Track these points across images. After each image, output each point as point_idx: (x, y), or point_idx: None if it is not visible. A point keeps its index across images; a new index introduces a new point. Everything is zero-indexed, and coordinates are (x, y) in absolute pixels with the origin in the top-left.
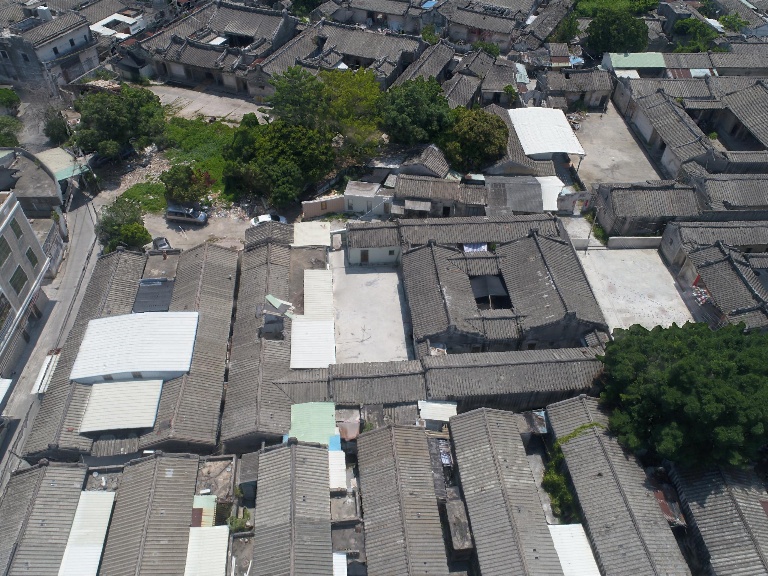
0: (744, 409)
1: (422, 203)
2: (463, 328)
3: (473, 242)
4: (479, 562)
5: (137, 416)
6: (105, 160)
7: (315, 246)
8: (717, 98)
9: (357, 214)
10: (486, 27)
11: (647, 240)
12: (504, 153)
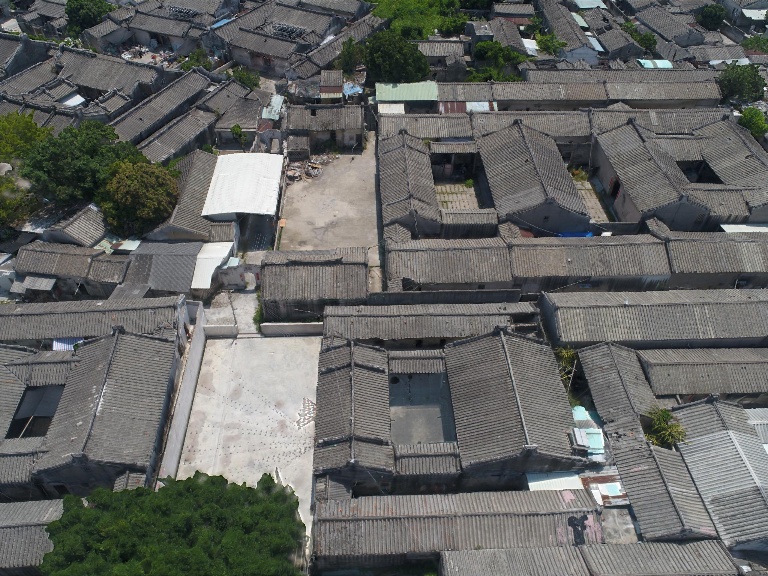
0: None
1: (45, 280)
2: None
3: (65, 337)
4: None
5: None
6: None
7: None
8: (475, 139)
9: None
10: (265, 51)
11: (308, 326)
12: (166, 215)
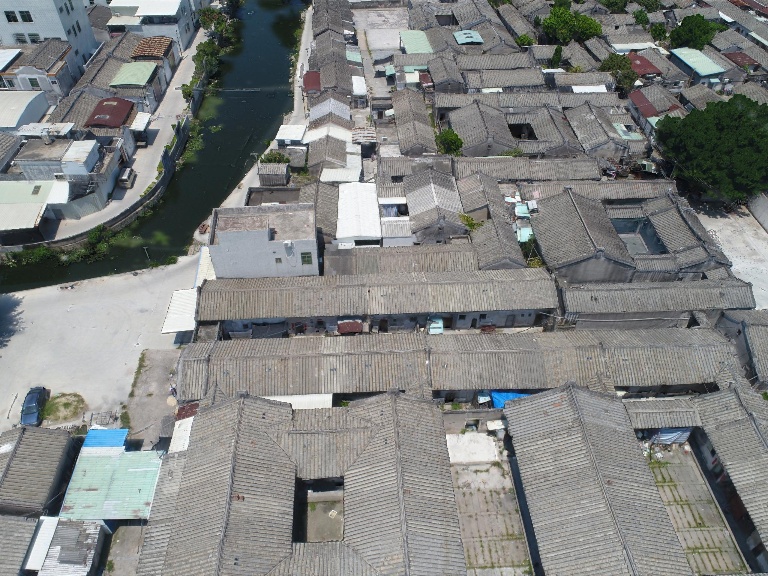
0: None
1: None
2: None
3: None
4: None
5: None
6: None
7: None
8: None
9: None
10: None
11: None
12: None
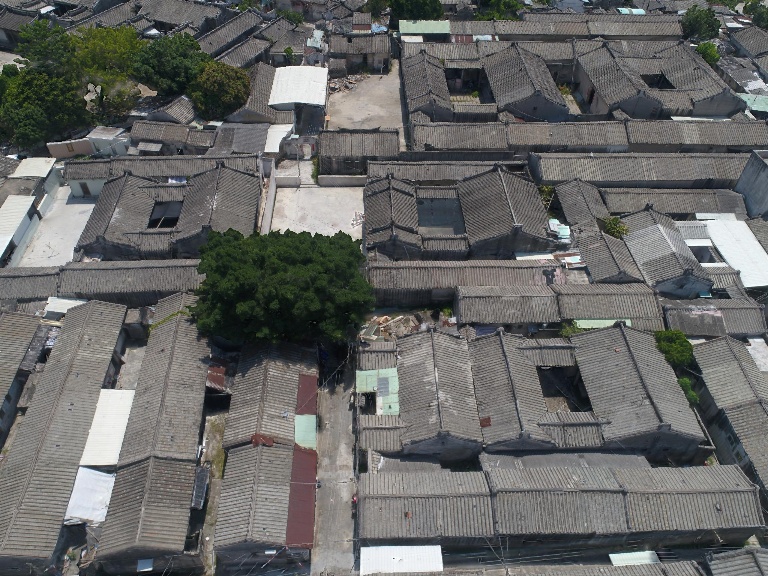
0: (263, 288)
1: (154, 145)
2: (116, 240)
3: (177, 175)
4: (25, 414)
5: None
6: None
7: (30, 177)
8: None
9: (104, 156)
10: None
11: (354, 179)
12: (242, 102)
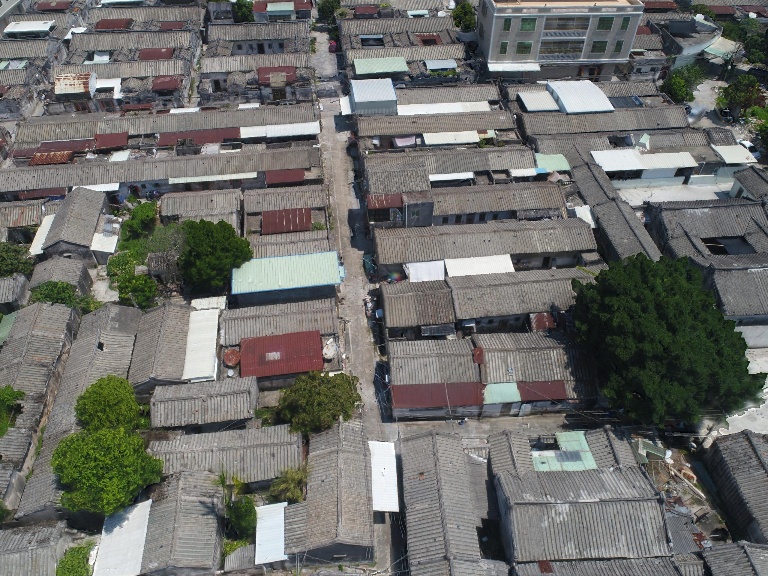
0: None
1: None
2: (667, 220)
3: None
4: None
5: (533, 105)
6: (758, 74)
7: (720, 155)
8: None
9: None
10: None
11: None
12: None
